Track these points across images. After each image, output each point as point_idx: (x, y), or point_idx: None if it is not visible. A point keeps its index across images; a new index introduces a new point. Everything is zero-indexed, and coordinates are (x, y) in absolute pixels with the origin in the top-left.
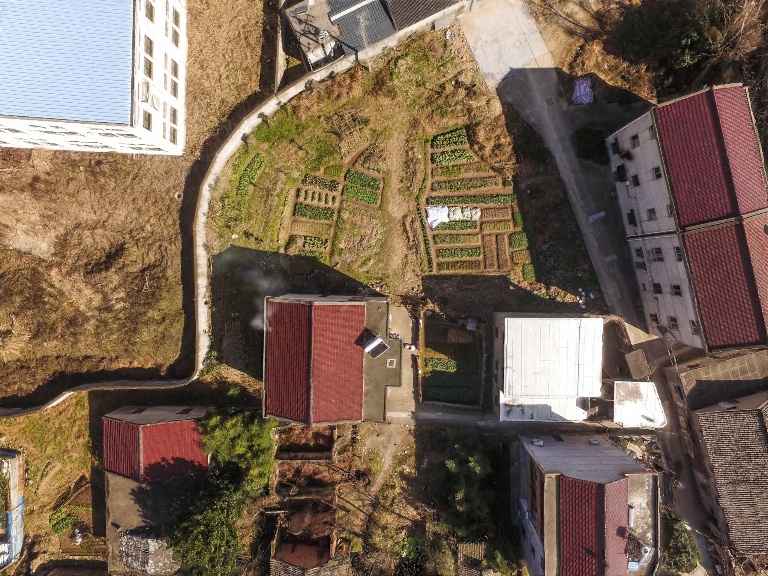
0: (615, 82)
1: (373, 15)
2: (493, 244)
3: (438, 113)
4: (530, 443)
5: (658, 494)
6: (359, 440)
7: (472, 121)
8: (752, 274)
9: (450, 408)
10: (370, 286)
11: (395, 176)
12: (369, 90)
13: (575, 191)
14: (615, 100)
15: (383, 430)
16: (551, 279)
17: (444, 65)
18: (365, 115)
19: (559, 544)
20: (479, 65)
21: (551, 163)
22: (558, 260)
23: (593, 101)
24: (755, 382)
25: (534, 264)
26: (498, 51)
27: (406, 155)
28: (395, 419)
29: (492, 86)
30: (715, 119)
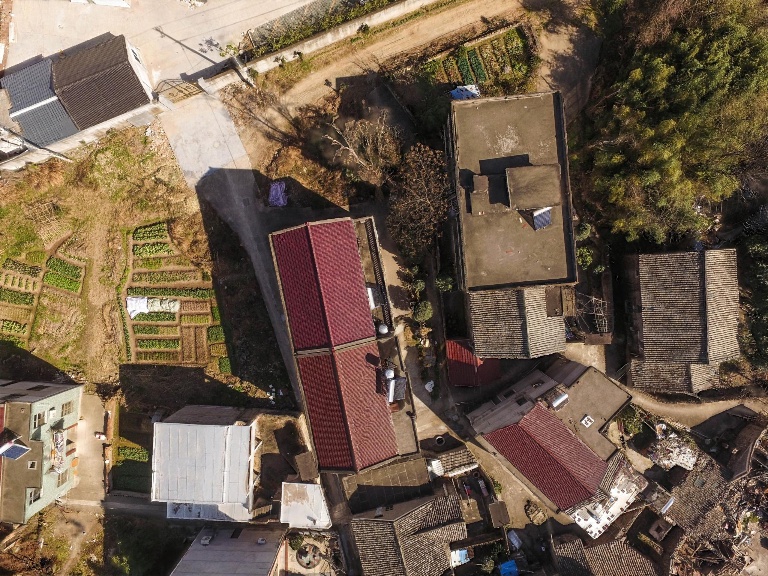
0: (312, 186)
1: (54, 114)
2: (191, 336)
3: (137, 207)
4: (199, 540)
5: None
6: (46, 527)
7: (172, 216)
8: (343, 403)
9: None
10: (67, 373)
11: (96, 265)
12: (71, 180)
13: (269, 290)
14: (309, 204)
15: (72, 518)
16: (244, 374)
17: (143, 161)
18: (66, 204)
19: None
20: (179, 163)
21: (245, 262)
22: (251, 356)
23: (287, 204)
24: (413, 489)
25: (230, 358)
26: (198, 150)
27: (107, 245)
28: (84, 507)
29: (191, 184)
30: (311, 254)
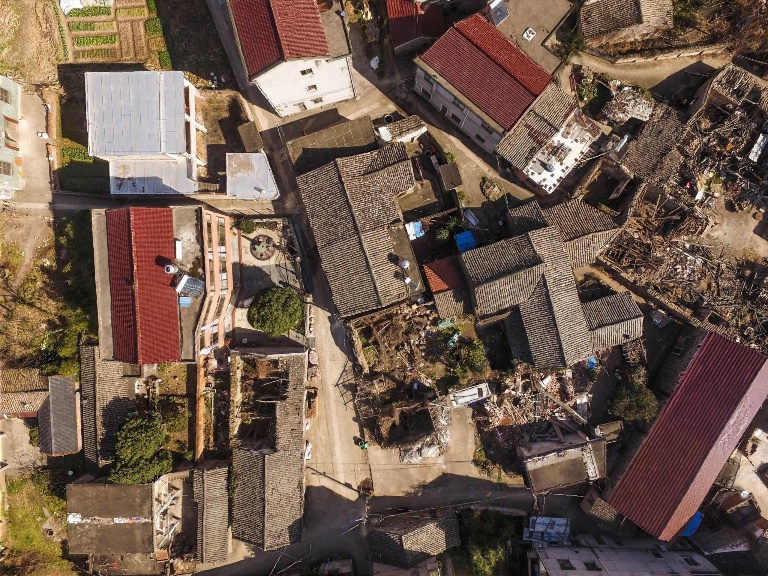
0: None
1: None
2: (128, 31)
3: None
4: None
5: (202, 225)
6: None
7: None
8: None
9: (87, 198)
10: (5, 75)
11: None
12: None
13: None
14: None
15: (22, 223)
16: (184, 64)
17: None
18: None
19: (110, 281)
20: None
21: None
22: (190, 44)
23: None
24: (360, 149)
25: (170, 51)
26: None
27: None
28: (32, 211)
29: None
30: None
